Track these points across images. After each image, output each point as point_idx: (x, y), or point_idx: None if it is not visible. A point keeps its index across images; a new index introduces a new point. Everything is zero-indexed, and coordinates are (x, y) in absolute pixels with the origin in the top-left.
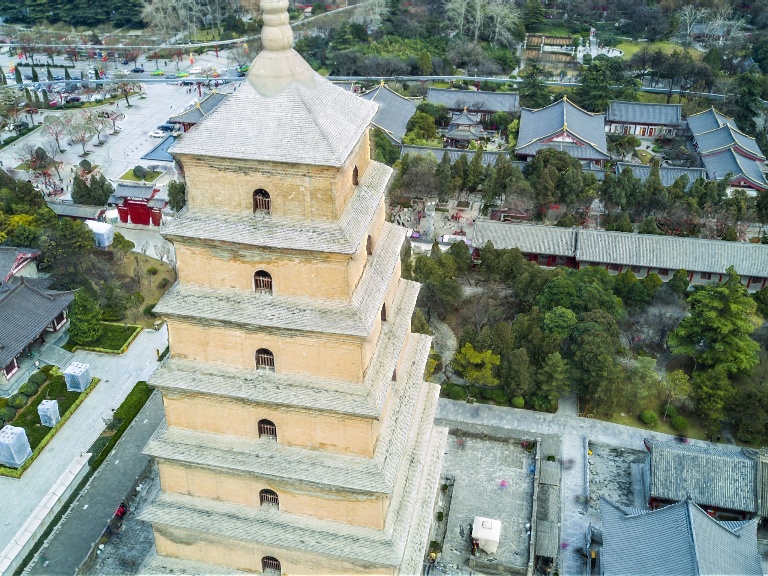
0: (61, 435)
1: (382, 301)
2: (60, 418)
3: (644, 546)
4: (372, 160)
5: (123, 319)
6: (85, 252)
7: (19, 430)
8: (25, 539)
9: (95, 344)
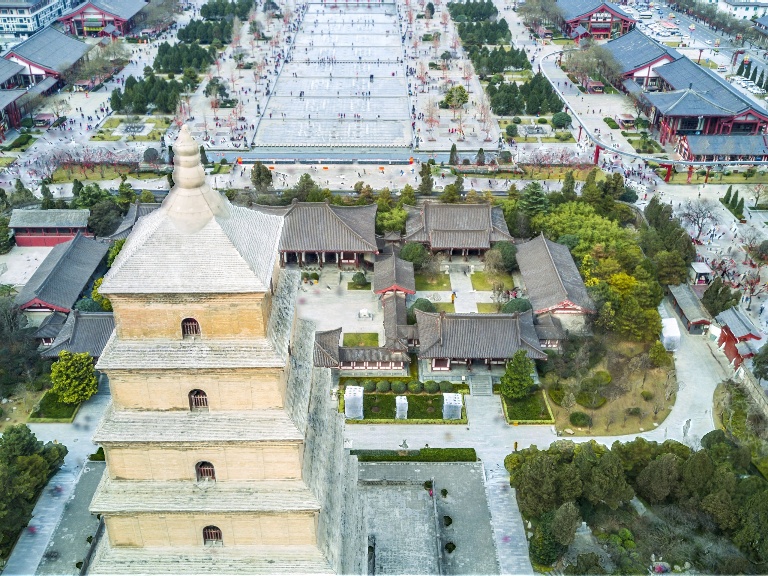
0: (391, 427)
1: (200, 456)
2: (407, 418)
3: None
4: (268, 340)
5: (560, 405)
6: (634, 339)
7: (359, 395)
8: None
9: (510, 401)
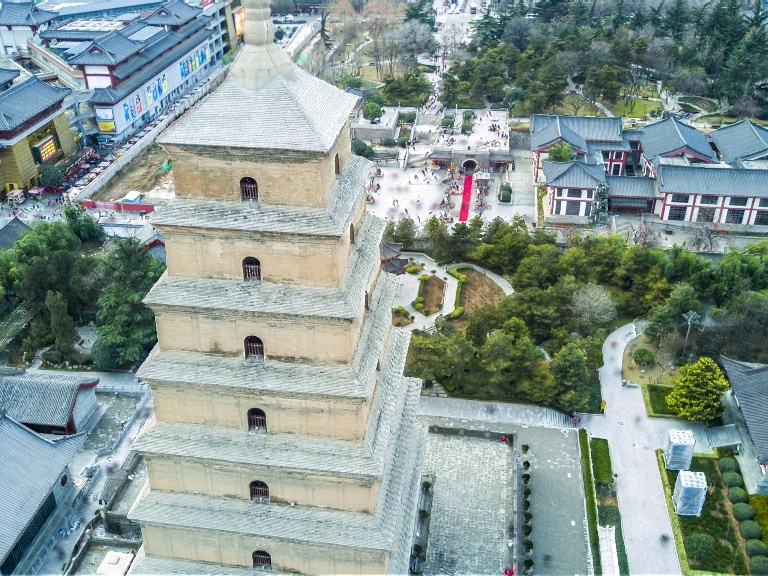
0: None
1: None
2: None
3: None
4: (174, 200)
5: None
6: None
7: None
8: (606, 572)
9: None
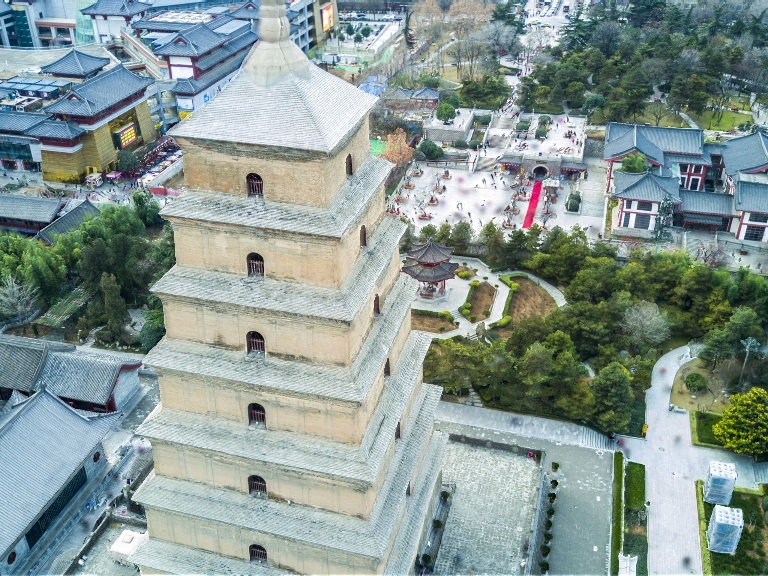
0: None
1: None
2: None
3: (2, 496)
4: (184, 193)
5: None
6: None
7: None
8: None
9: None
